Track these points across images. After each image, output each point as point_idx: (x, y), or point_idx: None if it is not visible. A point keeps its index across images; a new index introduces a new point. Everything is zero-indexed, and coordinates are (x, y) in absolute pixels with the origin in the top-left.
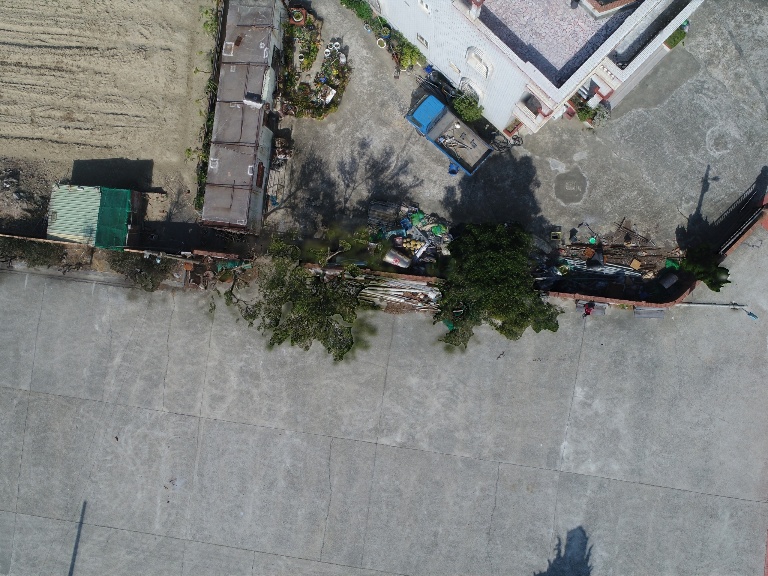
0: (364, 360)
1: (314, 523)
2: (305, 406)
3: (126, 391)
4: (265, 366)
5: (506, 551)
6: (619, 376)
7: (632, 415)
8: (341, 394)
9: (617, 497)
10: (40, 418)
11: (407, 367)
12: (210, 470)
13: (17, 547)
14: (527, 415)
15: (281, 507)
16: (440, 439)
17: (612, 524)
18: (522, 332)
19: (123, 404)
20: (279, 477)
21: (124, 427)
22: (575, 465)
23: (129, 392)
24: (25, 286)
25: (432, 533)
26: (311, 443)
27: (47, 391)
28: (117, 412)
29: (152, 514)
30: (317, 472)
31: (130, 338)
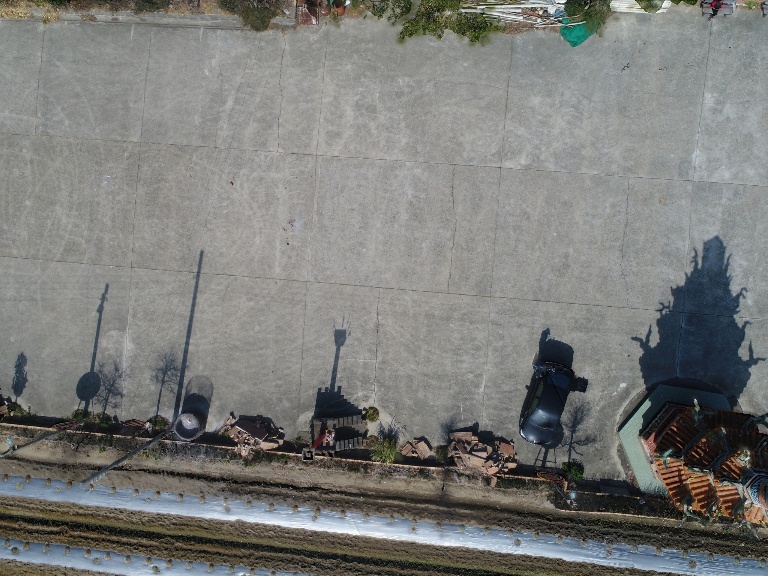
0: (484, 83)
1: (440, 254)
2: (425, 135)
3: (239, 135)
4: (381, 98)
5: (641, 267)
6: (749, 79)
7: (765, 117)
8: (461, 120)
9: (754, 203)
10: (152, 169)
11: (528, 87)
12: (329, 208)
13: (134, 302)
14: (656, 126)
15: (405, 240)
16: (566, 158)
17: (750, 231)
18: (662, 2)
19: (237, 148)
20: (401, 210)
21: (239, 171)
22: (708, 173)
23: (243, 135)
24: (131, 37)
25: (563, 255)
26: (433, 172)
27: (158, 141)
28: (231, 157)
29: (272, 258)
30: (440, 202)
31: (241, 80)
